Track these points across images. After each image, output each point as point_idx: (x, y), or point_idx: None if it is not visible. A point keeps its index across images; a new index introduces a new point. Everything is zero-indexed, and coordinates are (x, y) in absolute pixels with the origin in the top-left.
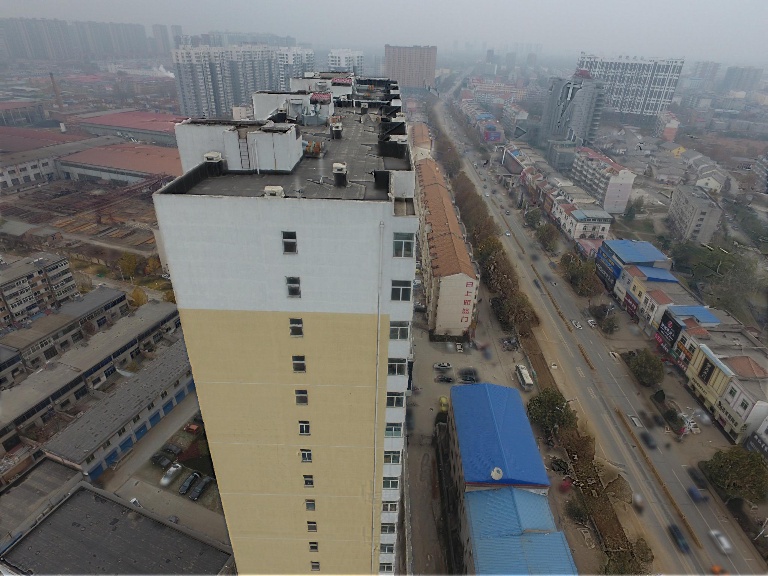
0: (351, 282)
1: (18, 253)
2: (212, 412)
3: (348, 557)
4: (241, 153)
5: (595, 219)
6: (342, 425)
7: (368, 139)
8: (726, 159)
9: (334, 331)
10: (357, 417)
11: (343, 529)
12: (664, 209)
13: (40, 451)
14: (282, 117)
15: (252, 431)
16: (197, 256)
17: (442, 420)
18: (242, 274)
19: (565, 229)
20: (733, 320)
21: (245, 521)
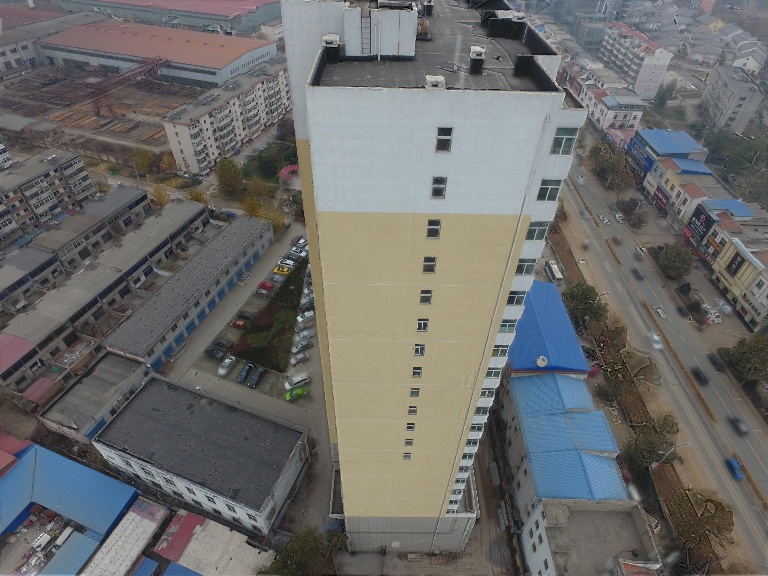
0: (500, 182)
1: (21, 150)
2: (336, 312)
3: (440, 435)
4: (362, 35)
5: (628, 106)
6: (460, 322)
7: (462, 16)
8: (767, 34)
9: (471, 232)
10: (476, 315)
11: (441, 412)
12: (697, 94)
13: (99, 346)
14: None
15: (372, 329)
16: (344, 156)
17: None
18: (388, 174)
19: (593, 118)
20: (767, 213)
21: (352, 407)
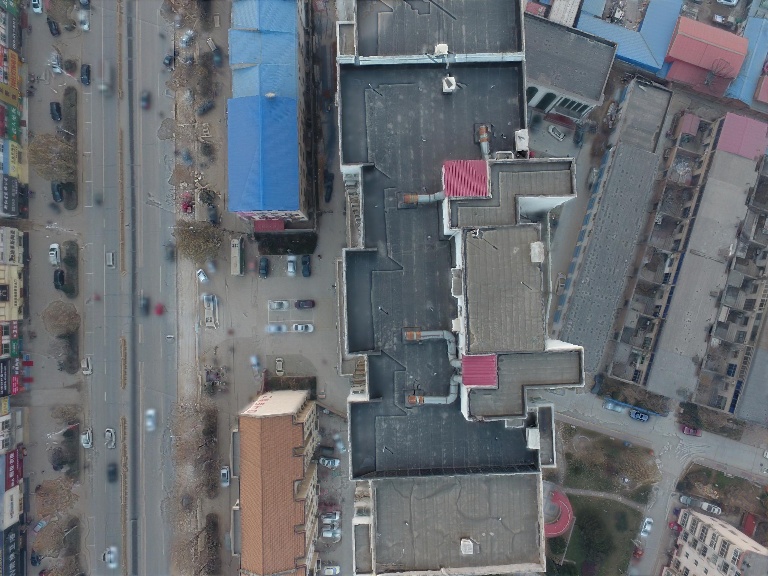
0: None
1: None
2: None
3: None
4: None
5: None
6: None
7: None
8: None
9: None
10: None
11: None
12: None
13: None
14: None
15: None
16: None
17: (310, 240)
18: None
19: None
20: None
21: None
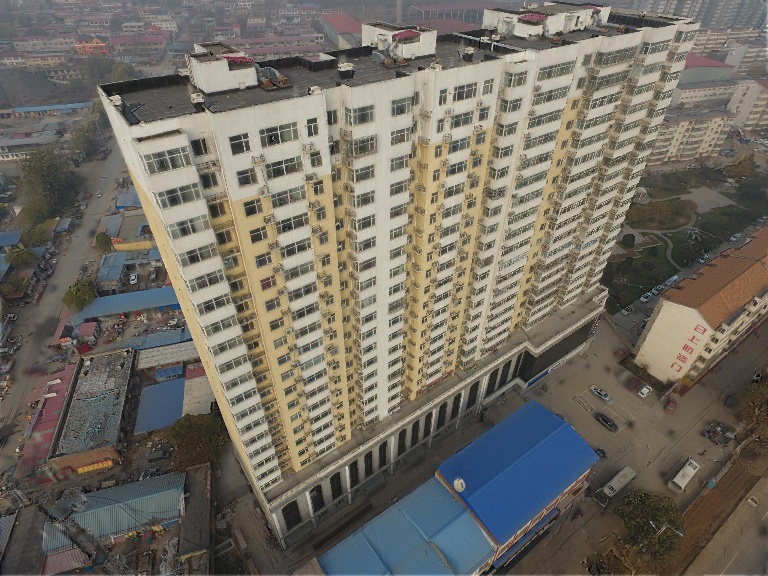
0: None
1: None
2: None
3: (219, 388)
4: None
5: None
6: None
7: None
8: None
9: None
10: None
11: None
12: None
13: None
14: (371, 50)
15: None
16: None
17: None
18: None
19: None
20: None
21: None
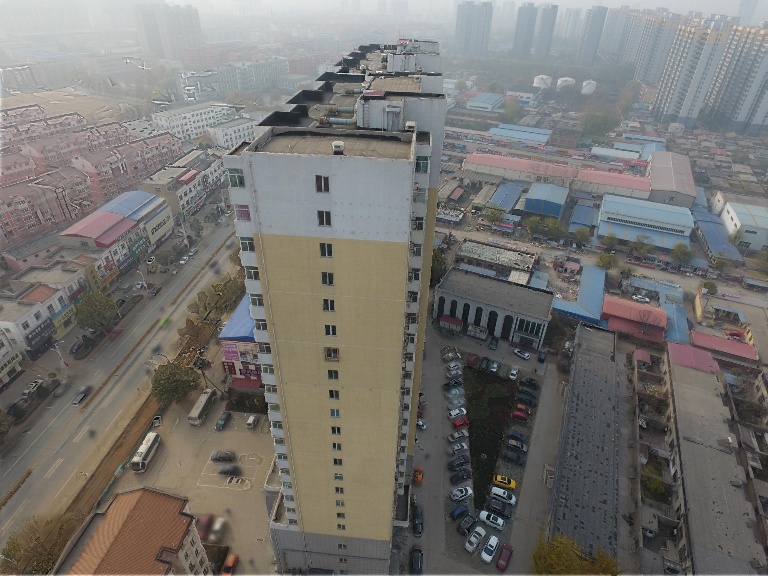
0: None
1: None
2: None
3: None
4: None
5: None
6: None
7: None
8: None
9: None
10: None
11: None
12: None
13: None
14: None
15: None
16: None
17: None
18: None
19: None
20: None
21: None
